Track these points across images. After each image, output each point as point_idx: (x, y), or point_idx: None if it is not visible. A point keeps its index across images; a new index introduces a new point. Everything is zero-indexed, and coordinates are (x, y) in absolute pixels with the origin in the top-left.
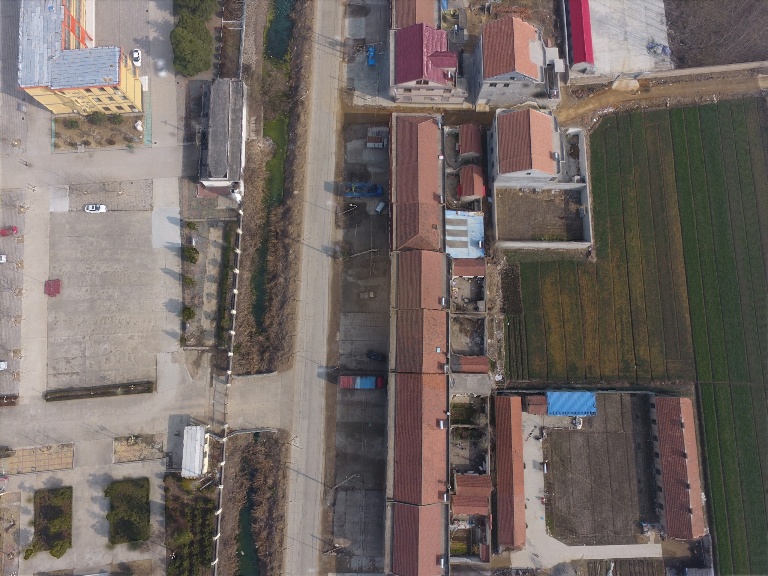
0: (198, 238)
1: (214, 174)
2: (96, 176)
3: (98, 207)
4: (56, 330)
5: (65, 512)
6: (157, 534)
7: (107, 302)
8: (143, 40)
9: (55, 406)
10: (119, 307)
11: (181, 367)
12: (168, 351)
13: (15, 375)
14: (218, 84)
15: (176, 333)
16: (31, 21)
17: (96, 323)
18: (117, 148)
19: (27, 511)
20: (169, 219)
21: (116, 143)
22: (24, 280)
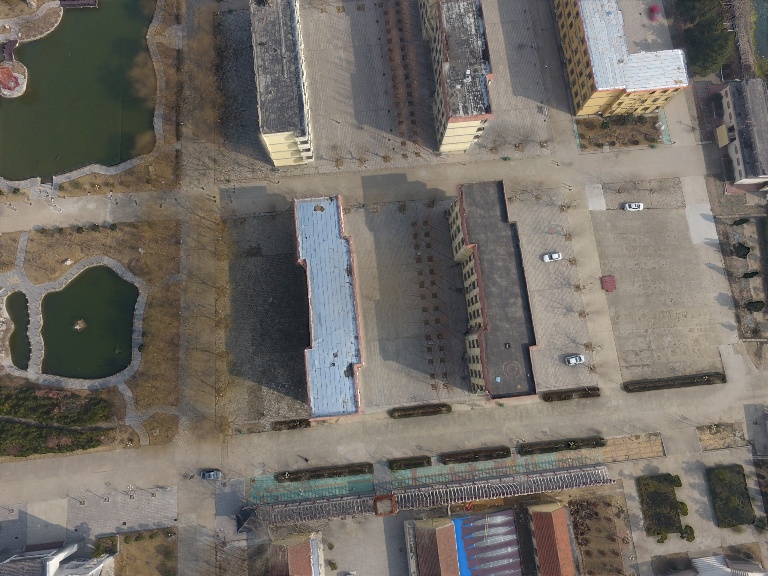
0: (734, 234)
1: (767, 172)
2: (626, 175)
3: (638, 205)
4: (619, 324)
5: (671, 498)
6: (758, 518)
7: (661, 297)
8: (643, 43)
9: (634, 397)
10: (674, 301)
11: (744, 358)
12: (728, 343)
13: (592, 368)
14: (752, 84)
15: (732, 326)
16: (594, 26)
17: (655, 317)
18: (639, 148)
19: (632, 497)
20: (702, 216)
21: (639, 143)
22: (580, 276)
